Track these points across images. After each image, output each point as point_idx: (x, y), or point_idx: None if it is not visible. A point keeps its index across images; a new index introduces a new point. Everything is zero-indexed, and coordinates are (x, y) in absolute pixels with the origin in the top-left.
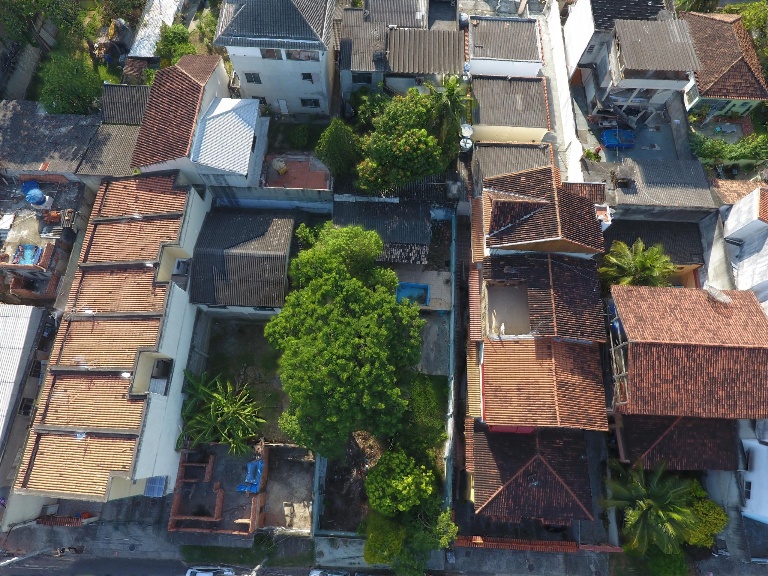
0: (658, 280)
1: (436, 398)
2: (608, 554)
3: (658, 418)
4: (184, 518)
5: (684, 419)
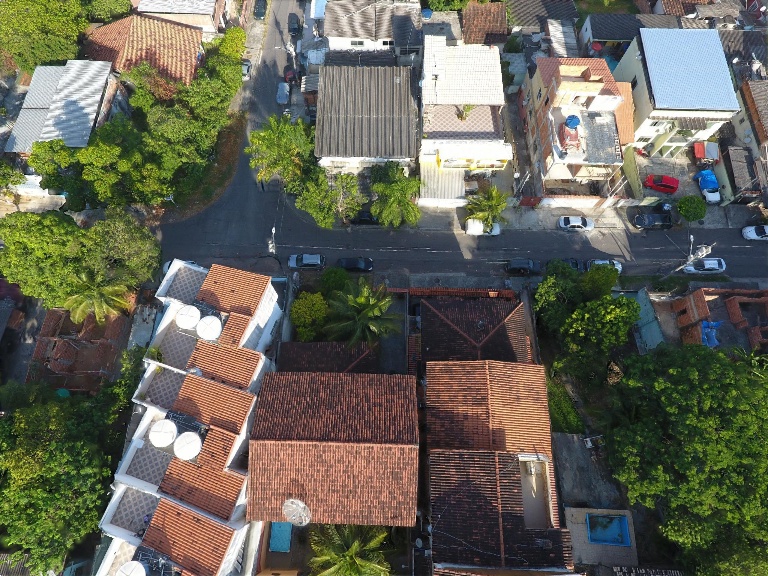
0: (334, 544)
1: (551, 409)
2: None
3: None
4: (763, 298)
5: None
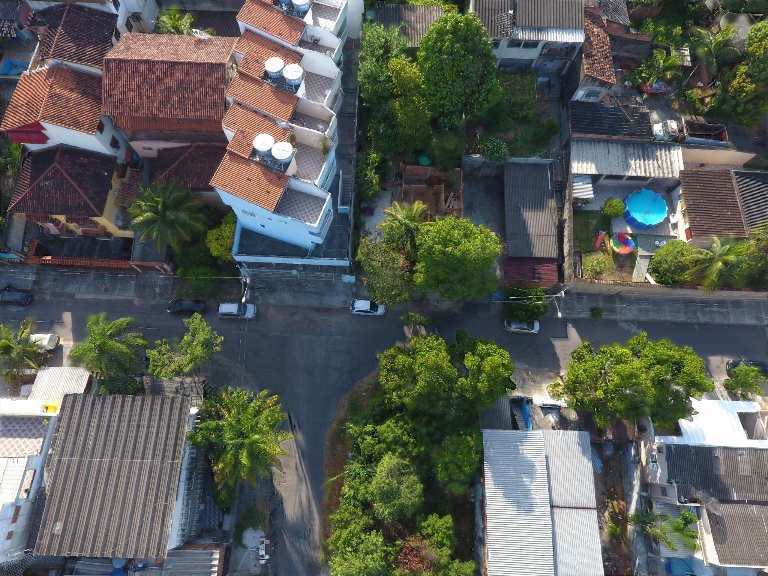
0: None
1: None
2: (172, 280)
3: (180, 149)
4: None
5: (197, 148)
